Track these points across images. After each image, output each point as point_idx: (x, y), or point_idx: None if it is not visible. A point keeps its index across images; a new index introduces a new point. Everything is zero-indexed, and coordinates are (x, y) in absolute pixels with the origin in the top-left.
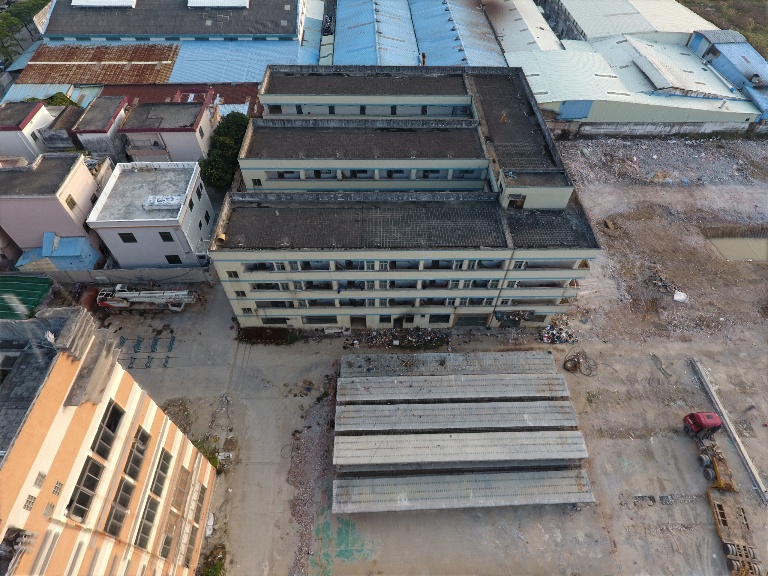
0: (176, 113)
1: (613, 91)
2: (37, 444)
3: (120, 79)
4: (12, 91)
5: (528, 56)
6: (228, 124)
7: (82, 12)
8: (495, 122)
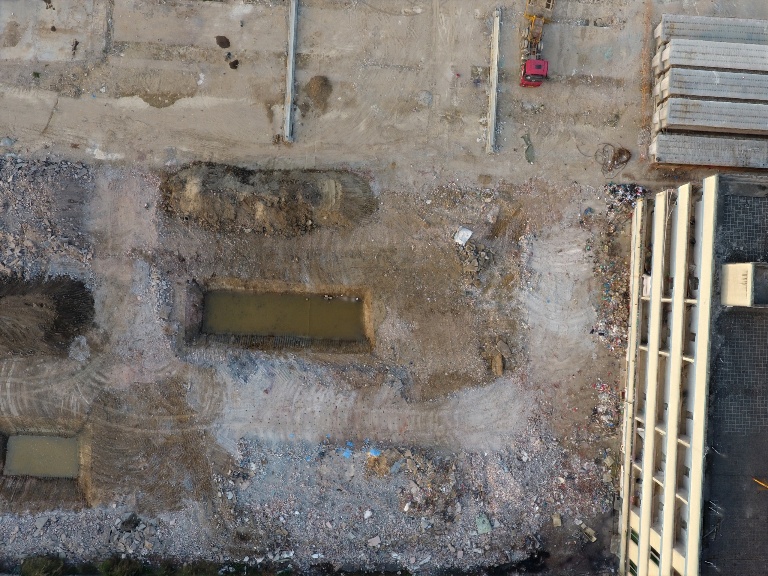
0: None
1: None
2: None
3: None
4: None
5: None
6: None
7: None
8: None
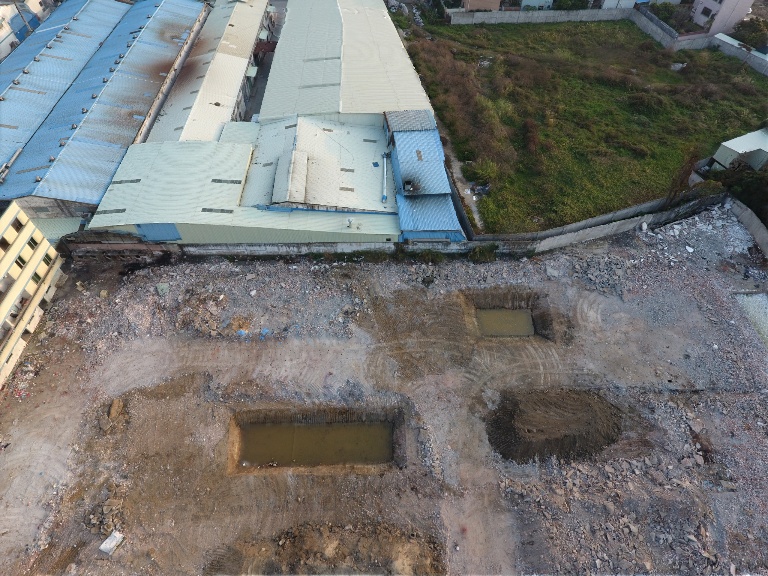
0: None
1: (212, 207)
2: None
3: None
4: None
5: (150, 151)
6: None
7: None
8: None
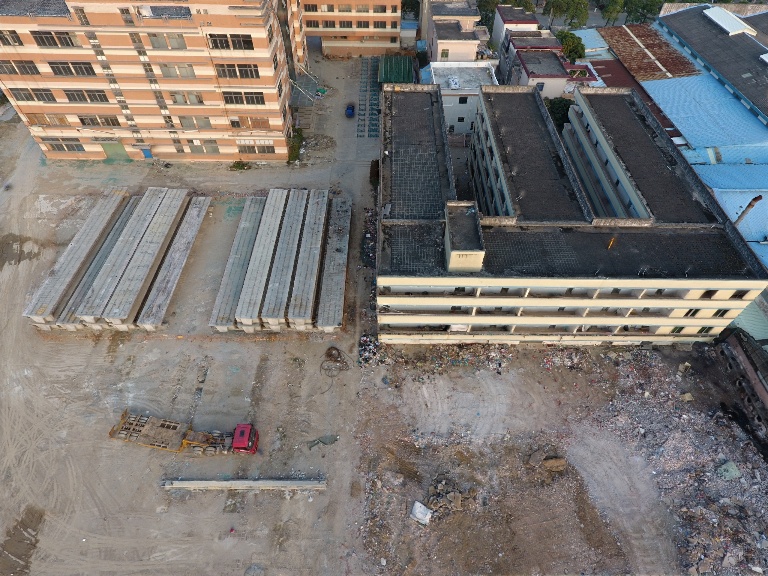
0: (550, 67)
1: None
2: (212, 2)
3: (629, 62)
4: (587, 30)
5: None
6: (564, 101)
7: (700, 19)
8: (607, 240)
